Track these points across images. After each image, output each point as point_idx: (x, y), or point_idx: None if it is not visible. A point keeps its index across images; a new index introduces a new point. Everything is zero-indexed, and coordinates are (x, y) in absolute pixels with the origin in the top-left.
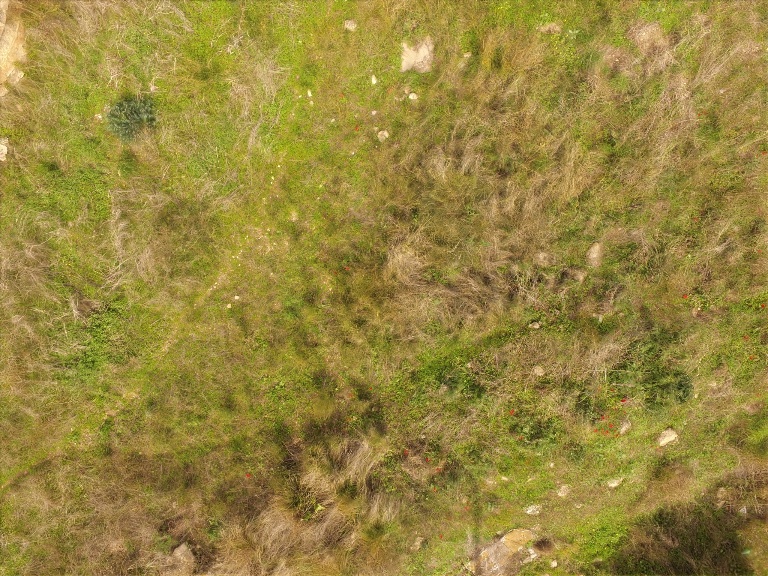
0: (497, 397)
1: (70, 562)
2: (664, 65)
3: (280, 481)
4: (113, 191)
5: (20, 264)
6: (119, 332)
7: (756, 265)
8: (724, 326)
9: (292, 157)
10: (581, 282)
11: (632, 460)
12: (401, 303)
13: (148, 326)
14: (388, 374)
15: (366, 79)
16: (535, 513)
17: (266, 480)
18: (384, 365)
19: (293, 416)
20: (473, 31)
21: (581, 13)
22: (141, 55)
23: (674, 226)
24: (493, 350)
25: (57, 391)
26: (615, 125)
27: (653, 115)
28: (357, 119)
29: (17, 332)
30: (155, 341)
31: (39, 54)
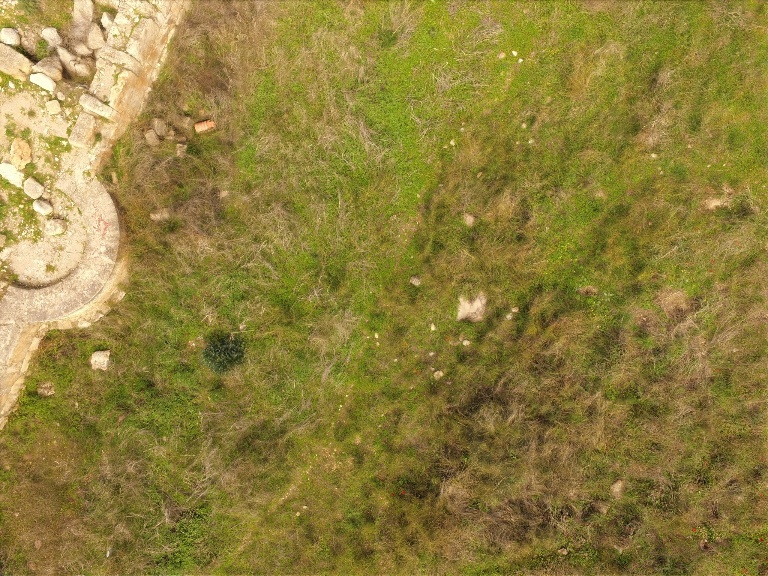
0: None
1: None
2: (685, 330)
3: None
4: (203, 413)
5: (123, 479)
6: (203, 535)
7: (757, 508)
8: (727, 558)
9: (359, 389)
10: (605, 514)
11: None
12: (451, 537)
13: (228, 530)
14: None
15: (426, 327)
16: None
17: None
18: (431, 575)
19: None
20: (521, 291)
21: (615, 281)
22: (233, 299)
23: (687, 465)
24: (526, 571)
25: None
26: (641, 384)
27: (674, 371)
28: (416, 359)
29: (118, 536)
30: (233, 542)
31: None
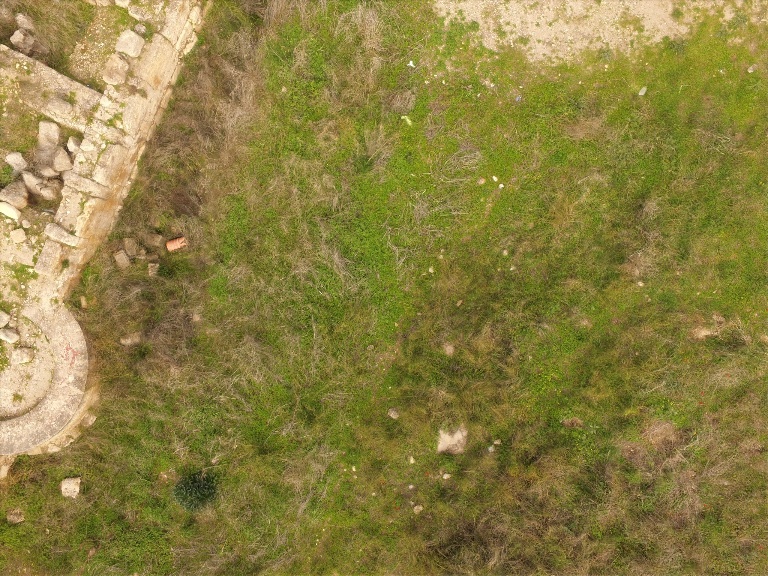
0: None
1: None
2: (674, 465)
3: None
4: (175, 549)
5: None
6: None
7: None
8: None
9: (336, 523)
10: None
11: None
12: None
13: None
14: None
15: (405, 460)
16: None
17: None
18: None
19: None
20: None
21: (601, 413)
22: (205, 432)
23: None
24: None
25: None
26: (628, 523)
27: None
28: (395, 492)
29: None
30: None
31: None
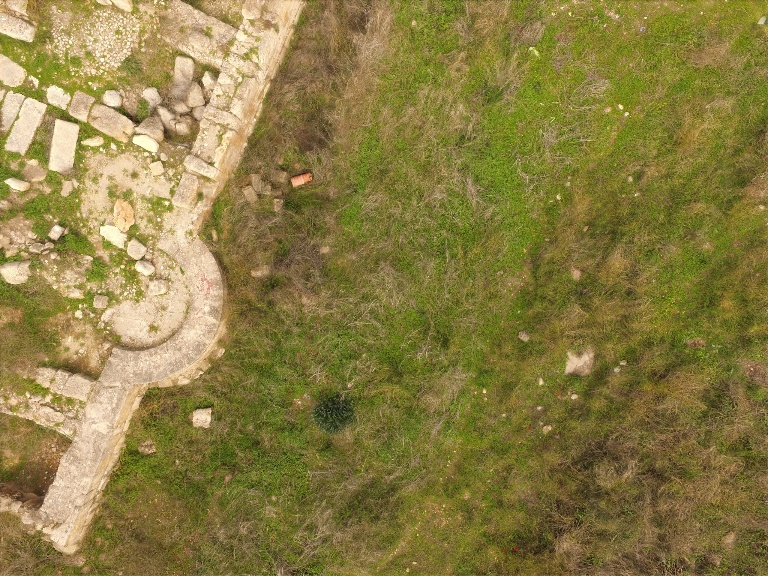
0: None
1: None
2: None
3: None
4: (312, 472)
5: (236, 541)
6: None
7: None
8: None
9: (467, 444)
10: (718, 566)
11: None
12: None
13: None
14: None
15: (534, 381)
16: None
17: None
18: None
19: None
20: None
21: (724, 332)
22: (341, 357)
23: None
24: None
25: None
26: (753, 436)
27: None
28: (524, 413)
29: None
30: None
31: None
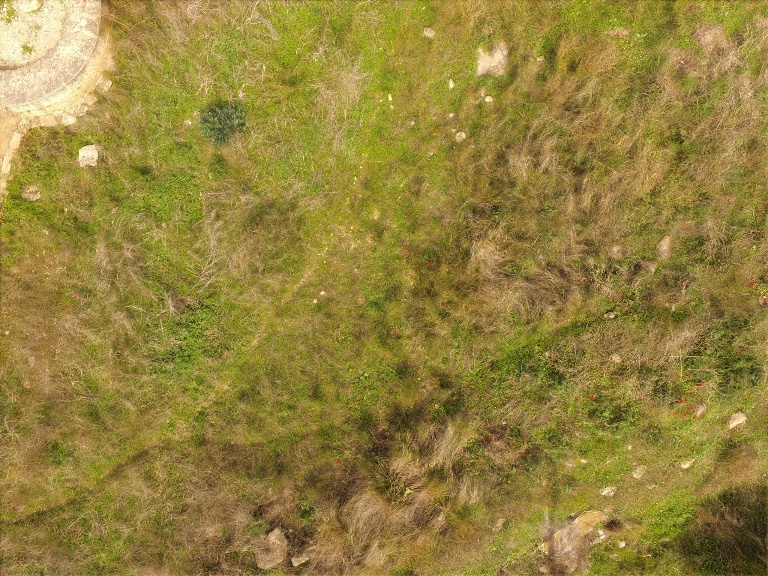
0: (576, 384)
1: (169, 547)
2: (729, 66)
3: (371, 466)
4: (204, 193)
5: (120, 264)
6: (212, 327)
7: None
8: None
9: (374, 158)
10: (653, 273)
11: (704, 442)
12: (487, 295)
13: (239, 321)
14: (469, 364)
15: (444, 83)
16: (610, 494)
17: (353, 467)
18: (465, 355)
19: (378, 405)
20: (546, 36)
21: (649, 17)
22: (230, 63)
23: (739, 219)
24: (571, 339)
25: (153, 384)
26: (684, 124)
27: (718, 113)
28: (435, 121)
29: (118, 329)
30: (246, 336)
31: (126, 64)
